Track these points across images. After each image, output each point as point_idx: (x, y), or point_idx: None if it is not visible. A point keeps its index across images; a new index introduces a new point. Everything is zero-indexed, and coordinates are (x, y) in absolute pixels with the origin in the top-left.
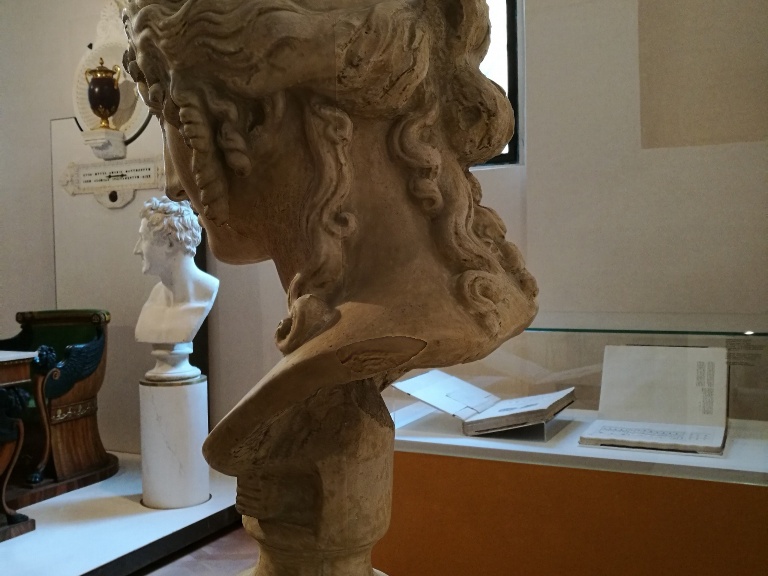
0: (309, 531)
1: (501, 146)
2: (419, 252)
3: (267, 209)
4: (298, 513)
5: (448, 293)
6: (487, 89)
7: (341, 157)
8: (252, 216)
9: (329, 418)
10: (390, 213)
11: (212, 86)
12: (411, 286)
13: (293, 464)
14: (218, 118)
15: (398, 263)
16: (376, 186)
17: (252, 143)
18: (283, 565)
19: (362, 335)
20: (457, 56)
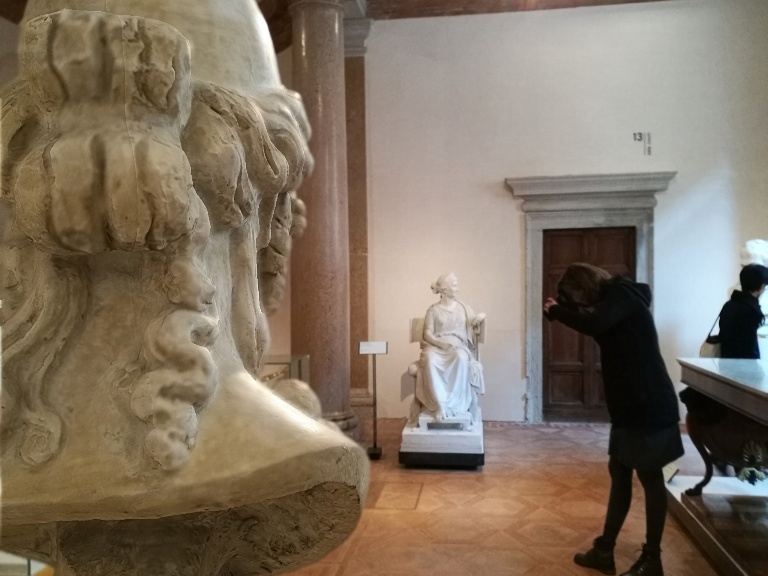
0: None
1: (118, 229)
2: None
3: None
4: None
5: None
6: (21, 163)
7: None
8: None
9: None
10: None
11: None
12: None
13: None
14: None
15: None
16: None
17: None
18: None
19: None
20: (43, 121)
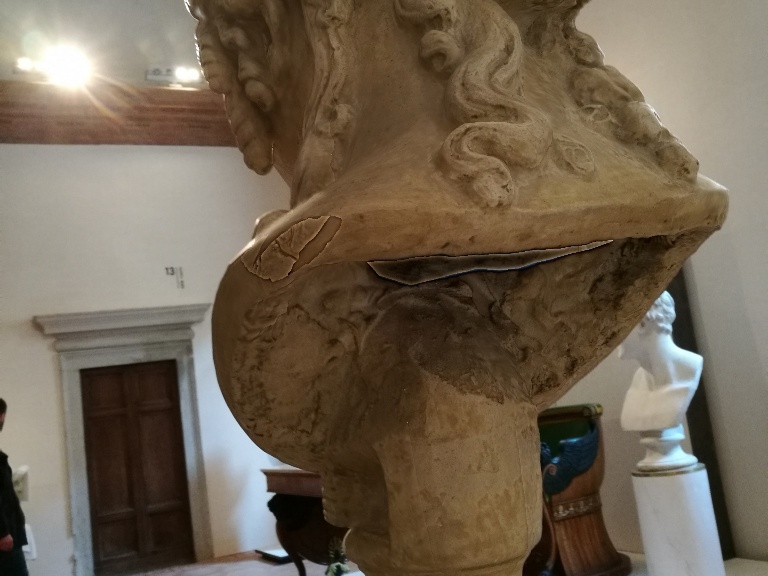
0: (385, 542)
1: None
2: (415, 124)
3: None
4: (384, 520)
5: (428, 161)
6: None
7: (333, 41)
8: None
9: (386, 384)
10: (392, 89)
11: (223, 19)
12: (374, 162)
13: (356, 450)
14: (236, 52)
15: (381, 143)
16: (380, 64)
17: (270, 68)
18: None
19: (271, 228)
20: None
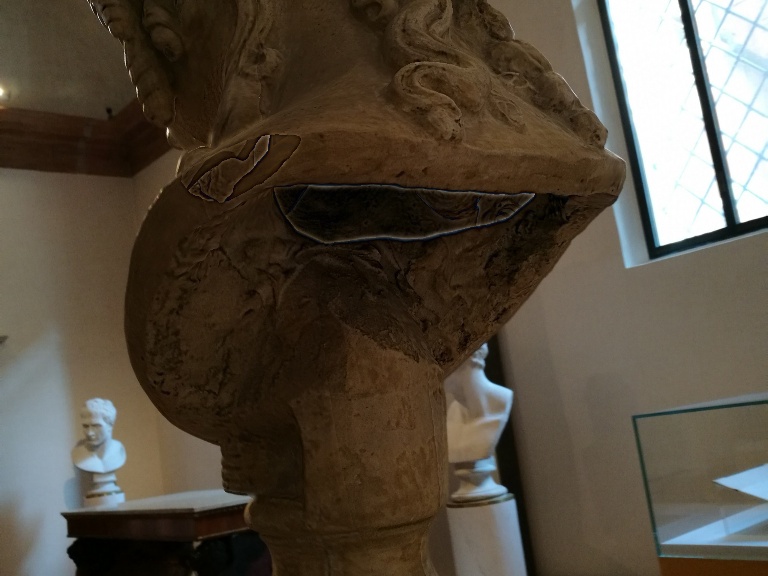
0: (298, 505)
1: None
2: (354, 67)
3: (214, 95)
4: (293, 485)
5: (376, 96)
6: None
7: None
8: (207, 113)
9: (304, 340)
10: (323, 36)
11: None
12: (319, 95)
13: (268, 411)
14: None
15: (319, 83)
16: (309, 12)
17: (179, 16)
18: (282, 562)
19: (216, 149)
20: None
